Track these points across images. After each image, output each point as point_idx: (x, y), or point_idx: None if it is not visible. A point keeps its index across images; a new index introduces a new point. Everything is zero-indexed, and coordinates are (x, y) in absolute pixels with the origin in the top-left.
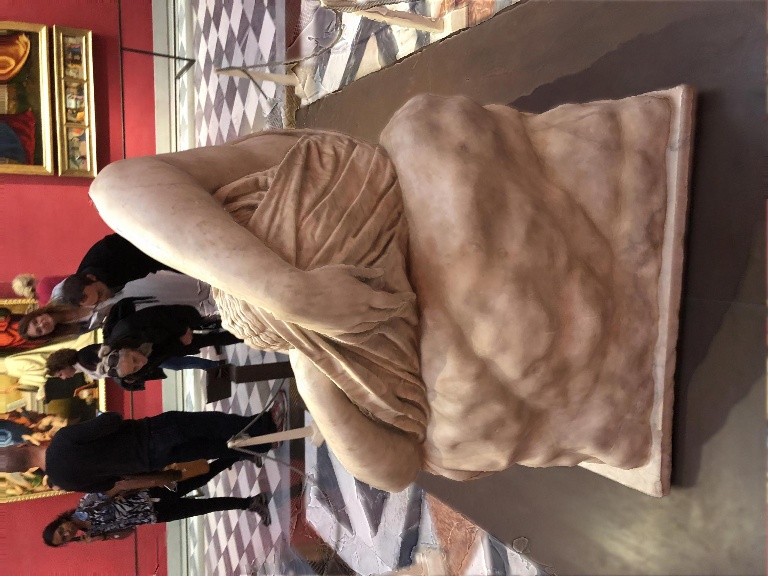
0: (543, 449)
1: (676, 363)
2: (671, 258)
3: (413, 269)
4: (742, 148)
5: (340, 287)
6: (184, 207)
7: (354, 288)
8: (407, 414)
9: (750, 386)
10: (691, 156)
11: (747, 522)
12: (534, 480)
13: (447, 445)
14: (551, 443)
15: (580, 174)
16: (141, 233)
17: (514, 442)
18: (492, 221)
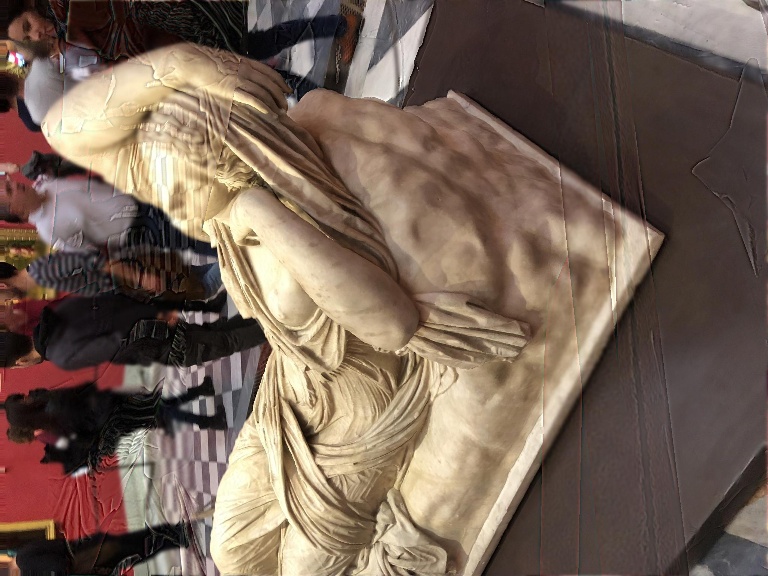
0: (511, 235)
1: None
2: (513, 135)
3: None
4: (498, 73)
5: None
6: None
7: None
8: (354, 221)
9: None
10: (483, 106)
11: None
12: None
13: (408, 235)
14: (514, 229)
15: None
16: None
17: (467, 214)
18: None
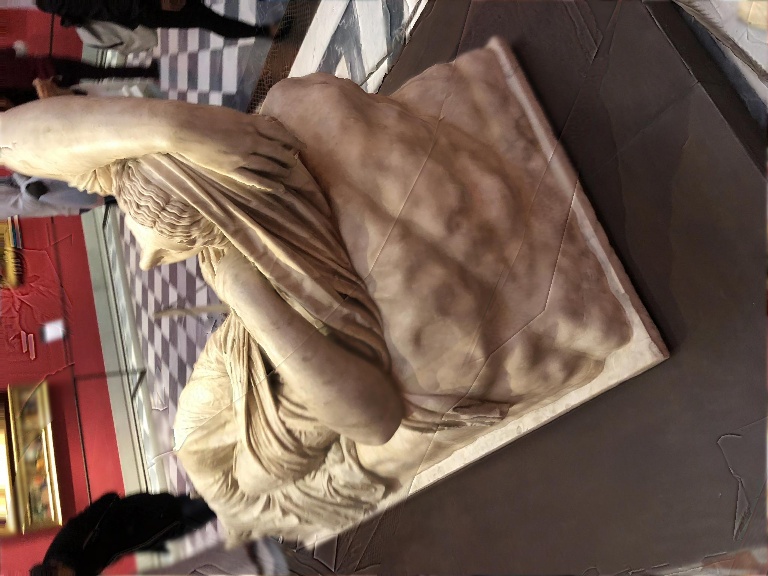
0: (516, 337)
1: (605, 233)
2: None
3: (308, 163)
4: None
5: (221, 107)
6: (69, 95)
7: (235, 110)
8: None
9: (671, 203)
10: None
11: (747, 321)
12: (561, 478)
13: None
14: None
15: (440, 105)
16: (32, 129)
17: None
18: (364, 109)
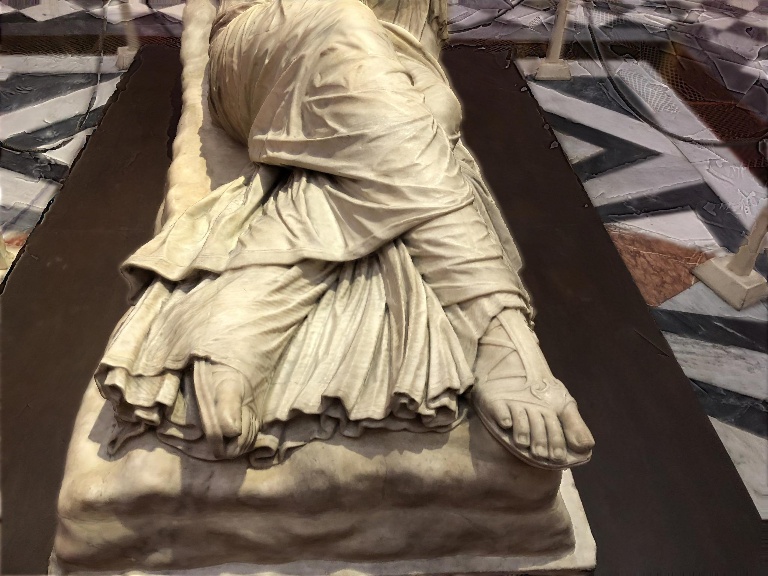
0: None
1: None
2: None
3: None
4: None
5: None
6: None
7: None
8: None
9: None
10: None
11: None
12: (486, 132)
13: None
14: None
15: None
16: None
17: None
18: None
